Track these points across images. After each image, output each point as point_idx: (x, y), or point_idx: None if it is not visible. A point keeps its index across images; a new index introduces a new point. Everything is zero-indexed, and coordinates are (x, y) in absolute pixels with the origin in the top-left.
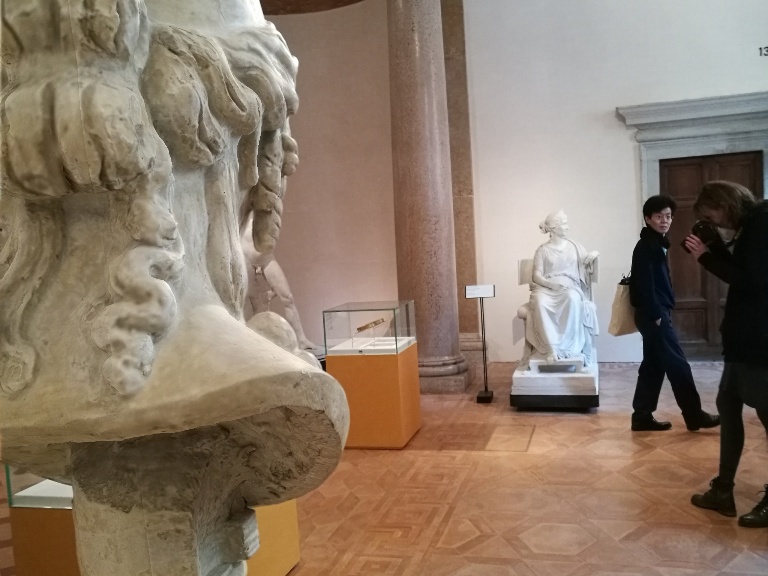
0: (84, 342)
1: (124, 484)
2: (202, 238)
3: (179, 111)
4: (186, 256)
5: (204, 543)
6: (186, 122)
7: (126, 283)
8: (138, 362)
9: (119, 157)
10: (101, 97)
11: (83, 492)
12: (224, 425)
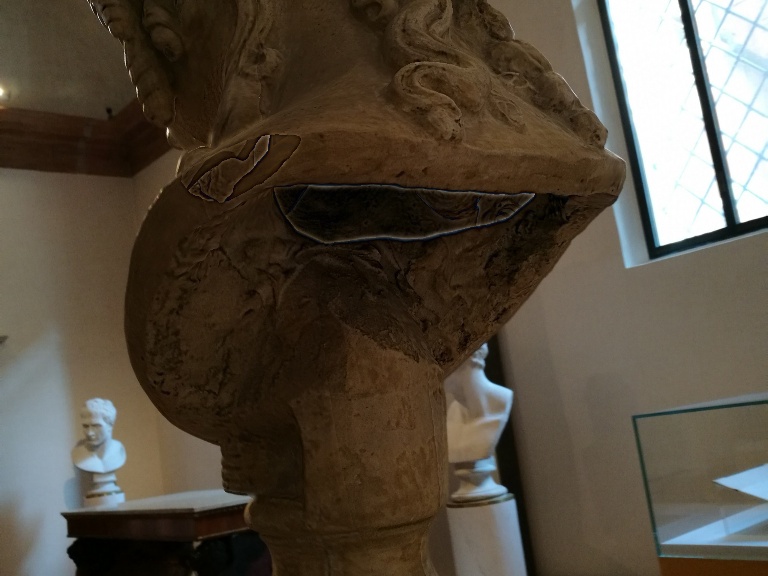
0: (526, 103)
1: (402, 331)
2: None
3: None
4: None
5: None
6: None
7: (542, 60)
8: None
9: None
10: None
11: (372, 339)
12: (416, 293)
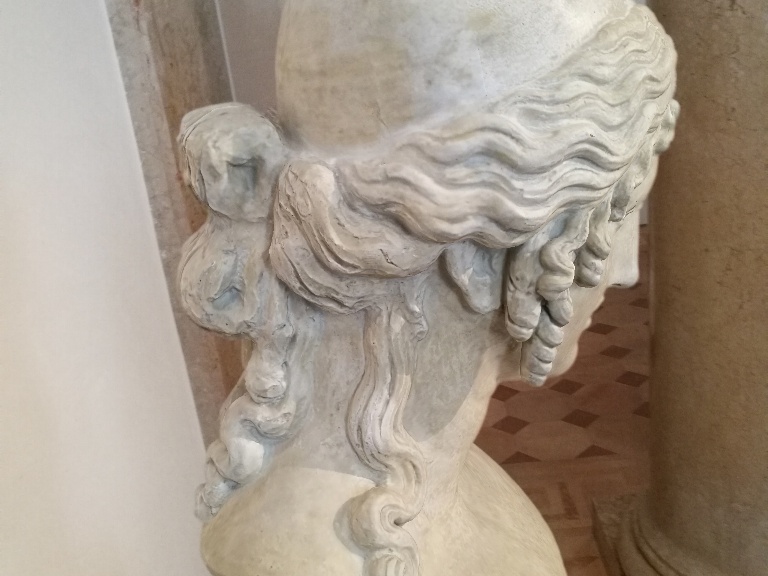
0: None
1: None
2: (350, 385)
3: (277, 271)
4: (318, 404)
5: None
6: (287, 282)
7: None
8: (206, 503)
9: None
10: (186, 268)
11: None
12: None
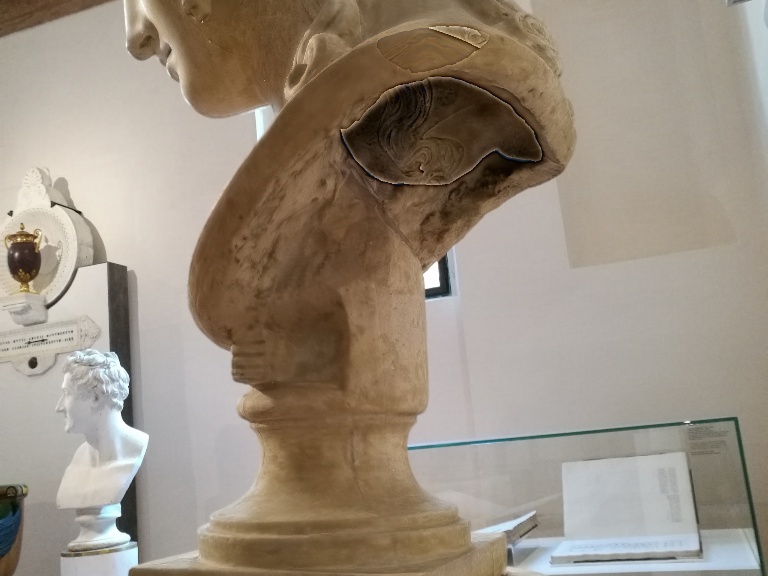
0: None
1: None
2: None
3: None
4: None
5: None
6: None
7: None
8: None
9: None
10: None
11: None
12: None
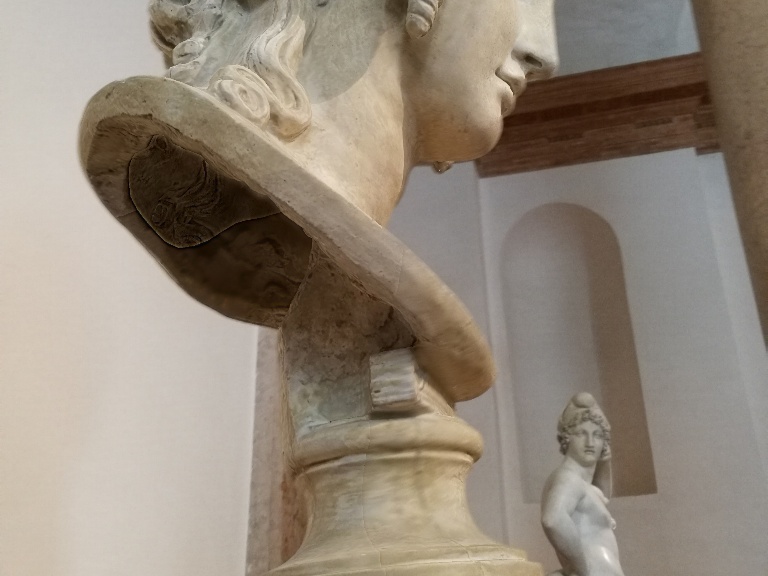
0: (157, 165)
1: None
2: None
3: None
4: None
5: (342, 383)
6: None
7: None
8: None
9: (154, 20)
10: None
11: None
12: None
